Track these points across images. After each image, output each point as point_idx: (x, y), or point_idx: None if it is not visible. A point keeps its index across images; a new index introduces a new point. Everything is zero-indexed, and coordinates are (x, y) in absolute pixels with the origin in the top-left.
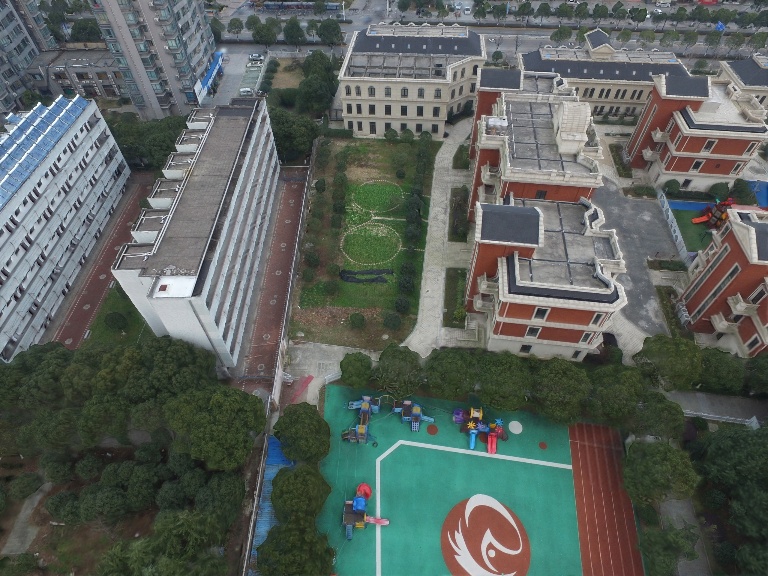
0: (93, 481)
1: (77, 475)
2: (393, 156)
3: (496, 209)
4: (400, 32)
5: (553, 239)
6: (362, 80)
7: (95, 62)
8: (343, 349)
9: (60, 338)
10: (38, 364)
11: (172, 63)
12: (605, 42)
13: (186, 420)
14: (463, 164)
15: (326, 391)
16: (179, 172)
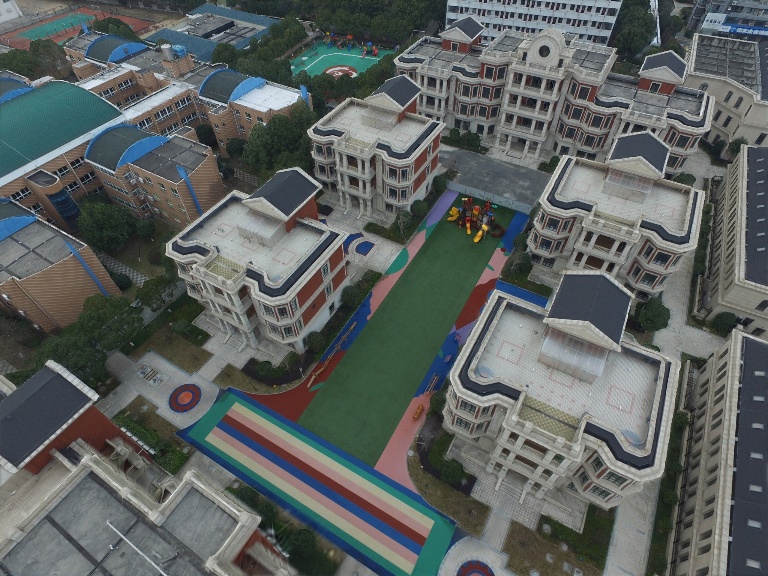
0: None
1: None
2: None
3: (471, 23)
4: None
5: (454, 59)
6: (693, 41)
7: None
8: None
9: None
10: None
11: None
12: None
13: None
14: None
15: None
16: None
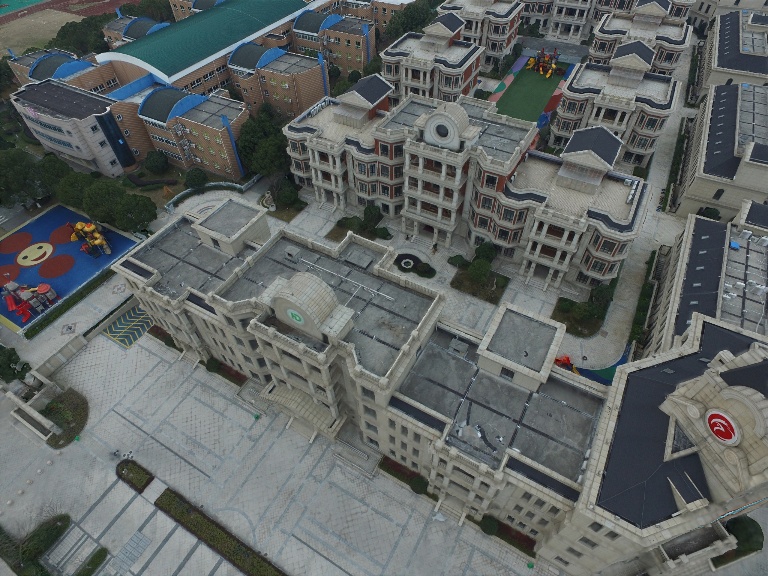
0: None
1: None
2: None
3: None
4: None
5: None
6: None
7: None
8: None
9: None
10: None
11: None
12: (759, 15)
13: None
14: None
15: None
16: None
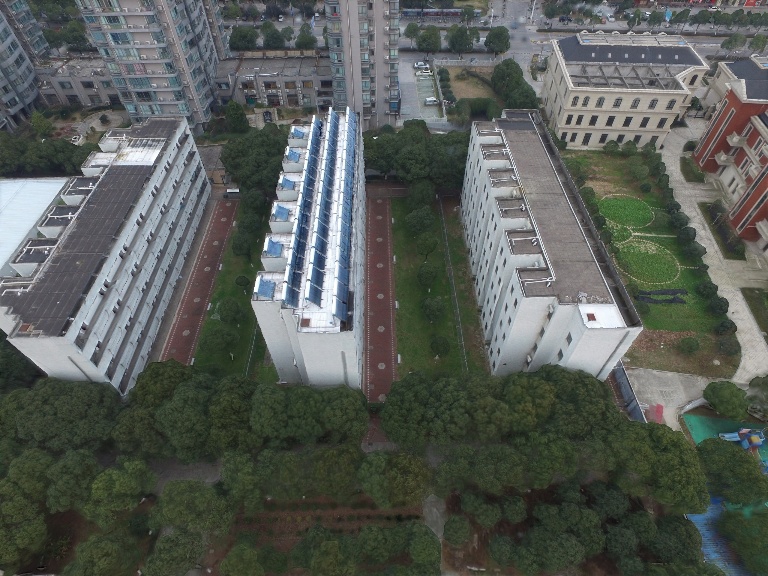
0: (527, 524)
1: (504, 517)
2: (632, 169)
3: None
4: (613, 41)
5: None
6: (596, 91)
7: (281, 71)
8: (678, 375)
9: (371, 363)
10: (429, 396)
11: (386, 73)
12: None
13: (651, 461)
14: (698, 177)
15: (686, 422)
16: (508, 190)
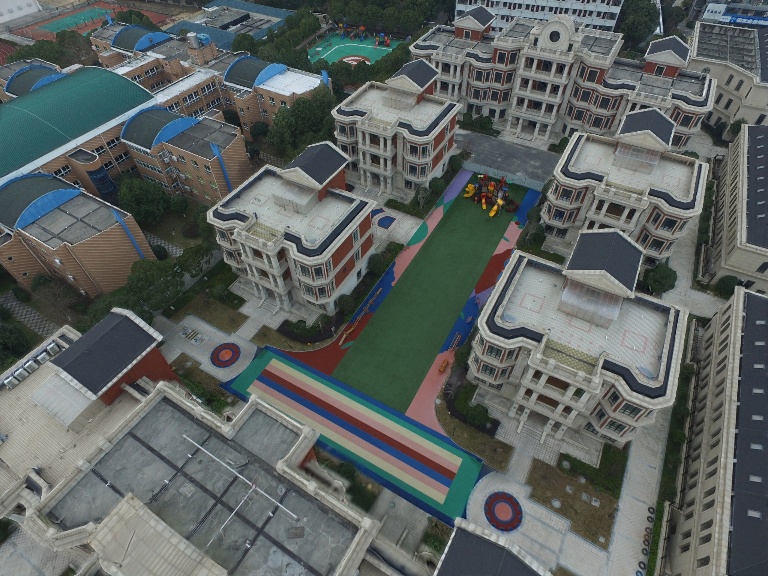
0: None
1: None
2: None
3: (482, 11)
4: None
5: (467, 46)
6: None
7: None
8: None
9: None
10: None
11: None
12: None
13: None
14: None
15: None
16: None
